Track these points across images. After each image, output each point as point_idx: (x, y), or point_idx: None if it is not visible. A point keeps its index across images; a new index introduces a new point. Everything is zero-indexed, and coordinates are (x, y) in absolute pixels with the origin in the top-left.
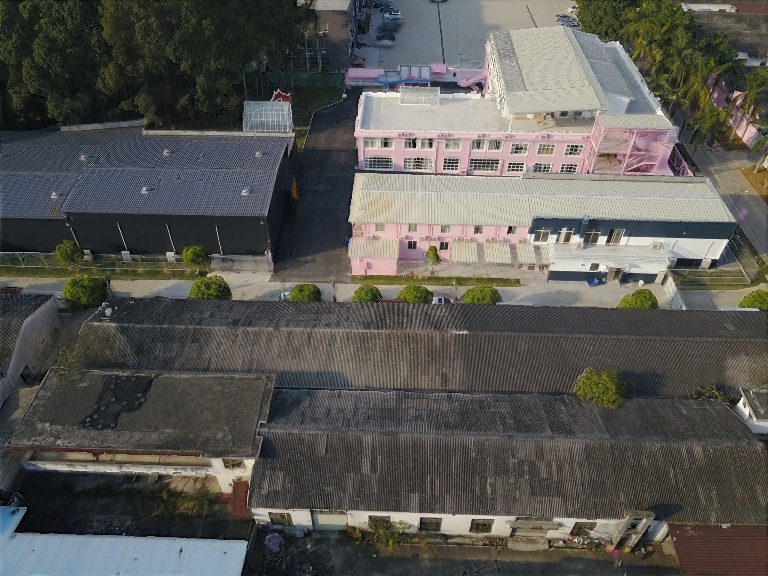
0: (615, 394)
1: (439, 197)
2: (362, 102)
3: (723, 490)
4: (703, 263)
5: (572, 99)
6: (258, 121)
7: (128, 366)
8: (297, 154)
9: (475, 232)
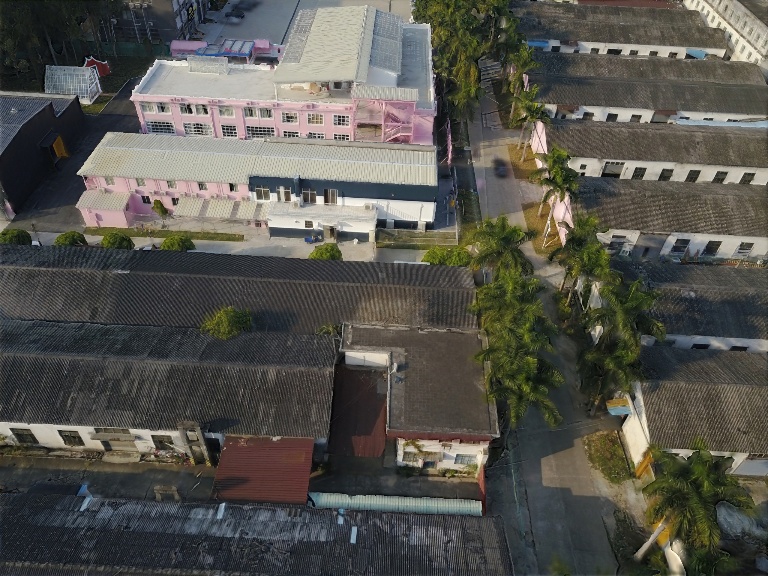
0: (229, 326)
1: (172, 155)
2: (151, 69)
3: (282, 408)
4: (419, 225)
5: (334, 71)
6: (59, 85)
7: None
8: (82, 116)
9: (200, 188)
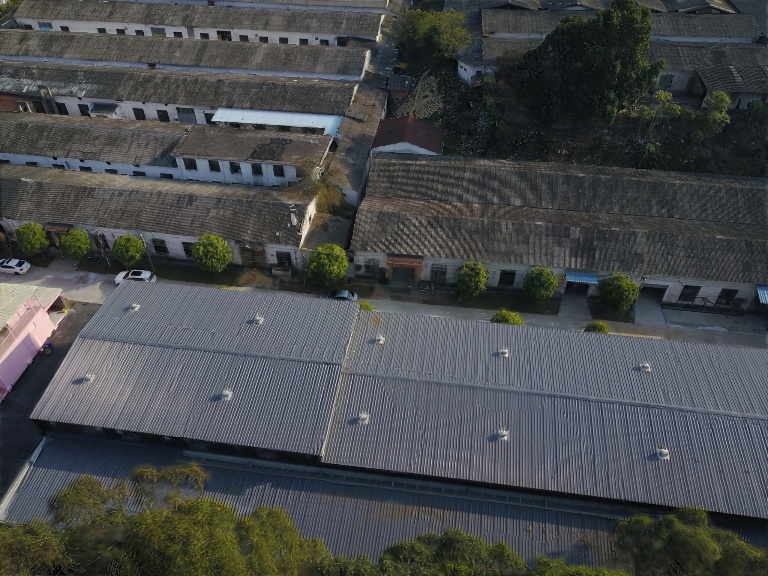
0: None
1: None
2: None
3: None
4: None
5: None
6: None
7: (276, 190)
8: None
9: None
